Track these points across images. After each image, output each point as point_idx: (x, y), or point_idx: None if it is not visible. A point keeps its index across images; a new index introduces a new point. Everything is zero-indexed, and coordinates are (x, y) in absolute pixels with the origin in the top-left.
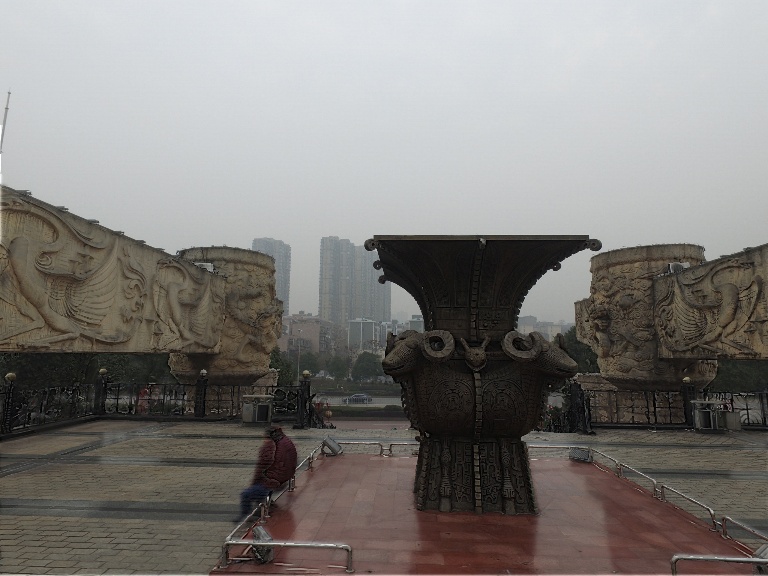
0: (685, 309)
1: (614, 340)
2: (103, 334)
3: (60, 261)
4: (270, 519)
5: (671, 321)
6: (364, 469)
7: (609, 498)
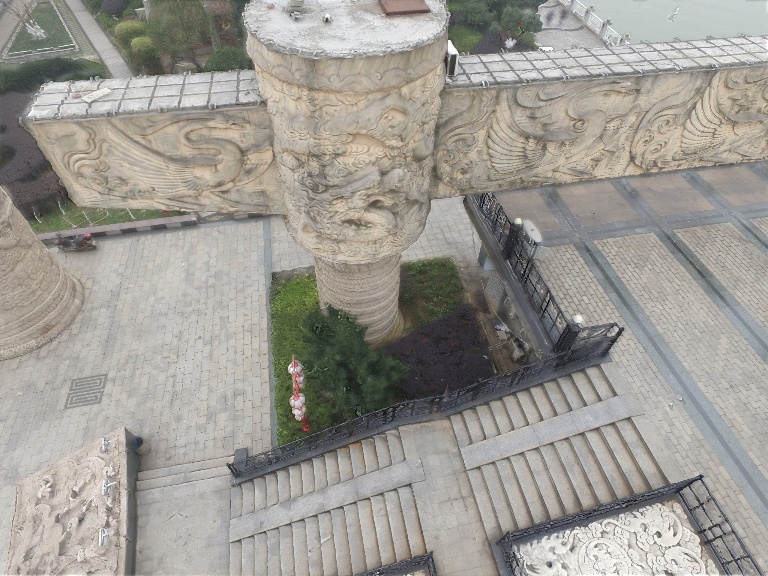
0: (511, 139)
1: (398, 211)
2: None
3: None
4: None
5: (471, 153)
6: None
7: None
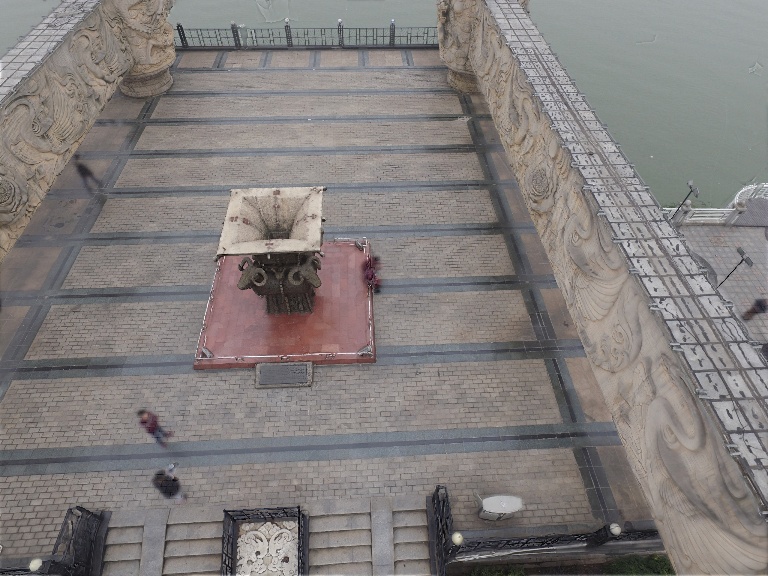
0: None
1: None
2: (586, 330)
3: (585, 248)
4: (366, 267)
5: None
6: (341, 325)
7: (233, 297)
